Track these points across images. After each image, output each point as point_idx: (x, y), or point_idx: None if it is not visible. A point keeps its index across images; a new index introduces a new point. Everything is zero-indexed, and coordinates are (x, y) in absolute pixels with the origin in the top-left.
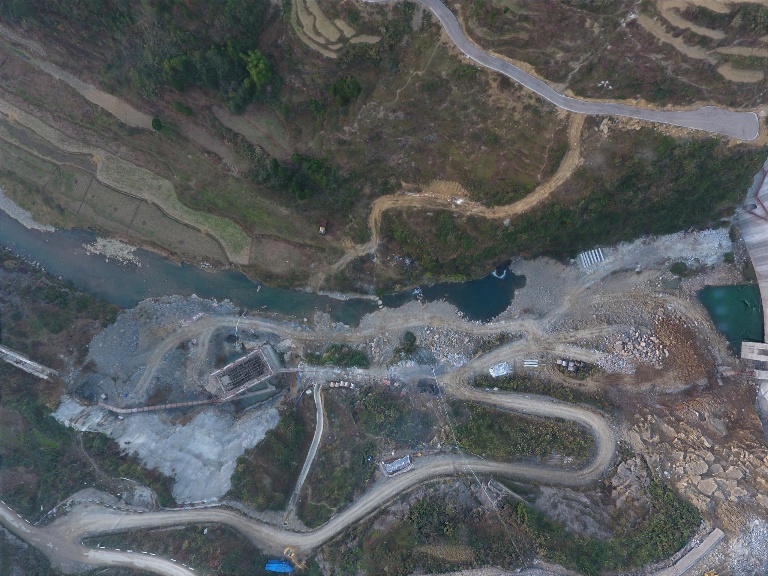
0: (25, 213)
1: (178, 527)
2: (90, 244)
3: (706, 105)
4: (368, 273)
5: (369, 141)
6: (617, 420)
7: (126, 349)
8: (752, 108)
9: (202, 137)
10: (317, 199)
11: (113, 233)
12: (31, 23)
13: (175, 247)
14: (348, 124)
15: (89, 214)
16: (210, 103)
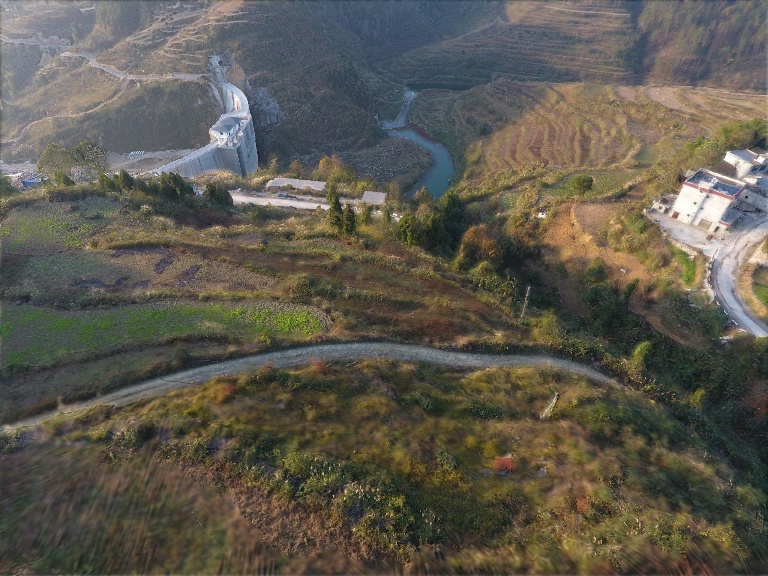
0: None
1: None
2: None
3: None
4: None
5: None
6: None
7: None
8: (197, 74)
9: None
10: None
11: None
12: None
13: None
14: None
15: None
16: None
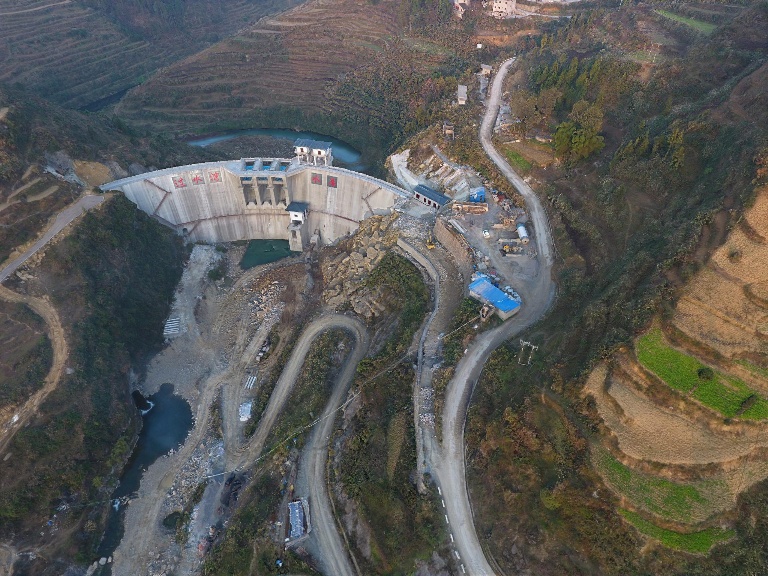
0: None
1: None
2: None
3: (56, 216)
4: (45, 570)
5: None
6: (317, 312)
7: None
8: (80, 196)
9: None
10: None
11: None
12: None
13: None
14: None
15: None
16: None
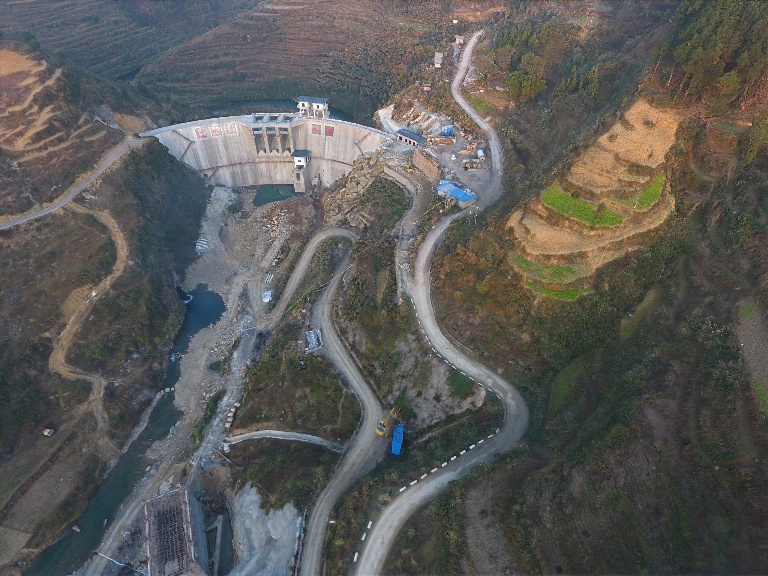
0: None
1: (323, 574)
2: None
3: (107, 153)
4: None
5: None
6: (320, 227)
7: None
8: (123, 139)
9: None
10: (5, 427)
11: None
12: None
13: None
14: None
15: None
16: None
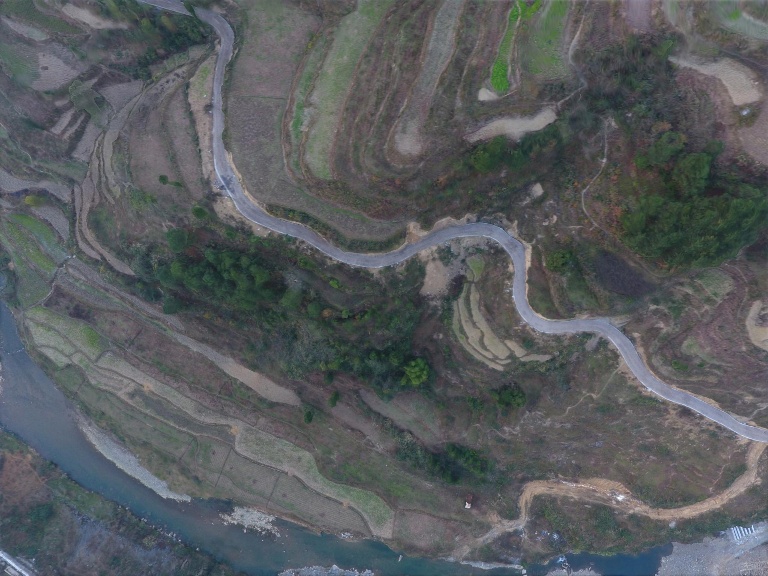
0: (160, 483)
1: None
2: (227, 514)
3: None
4: (515, 547)
5: (530, 442)
6: None
7: None
8: None
9: (346, 414)
10: (466, 480)
11: (252, 505)
12: None
13: (316, 520)
14: (509, 425)
15: (227, 486)
16: (358, 387)
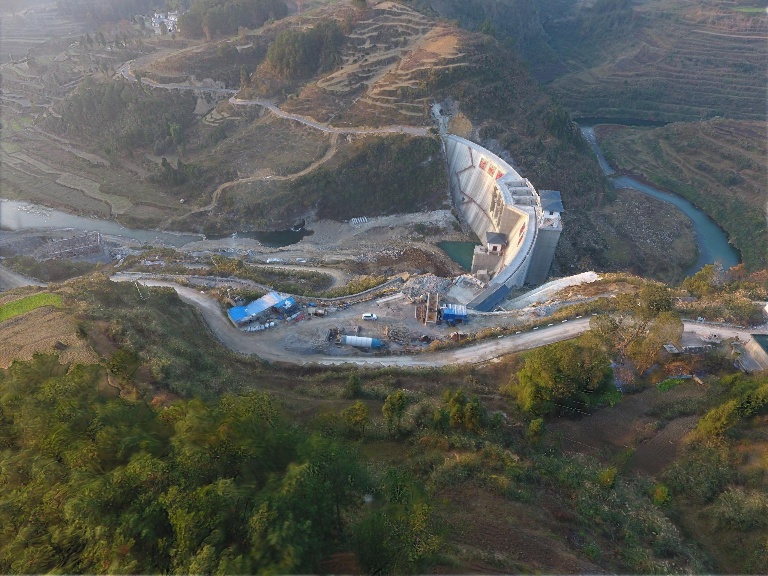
0: None
1: None
2: (24, 206)
3: (398, 126)
4: None
5: (224, 154)
6: (352, 272)
7: (1, 231)
8: (422, 127)
9: (132, 166)
10: (185, 185)
11: (44, 200)
12: (70, 129)
13: (80, 206)
14: None
15: (37, 193)
16: (145, 152)
